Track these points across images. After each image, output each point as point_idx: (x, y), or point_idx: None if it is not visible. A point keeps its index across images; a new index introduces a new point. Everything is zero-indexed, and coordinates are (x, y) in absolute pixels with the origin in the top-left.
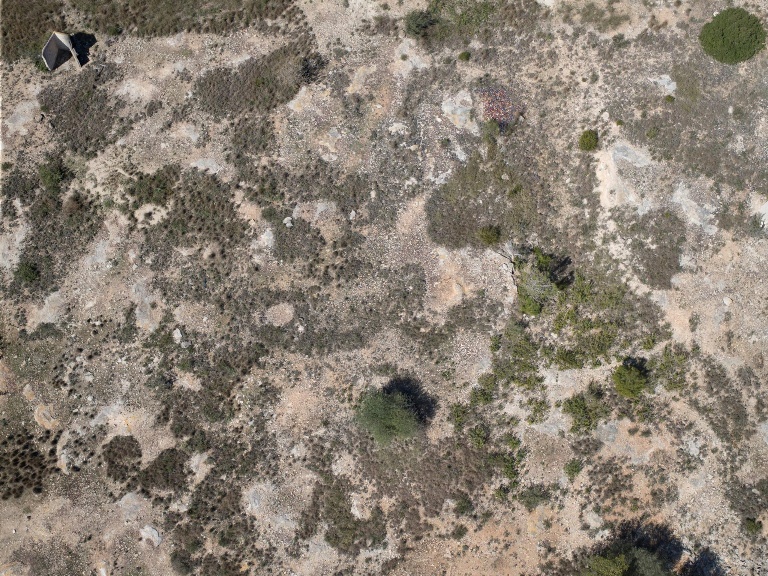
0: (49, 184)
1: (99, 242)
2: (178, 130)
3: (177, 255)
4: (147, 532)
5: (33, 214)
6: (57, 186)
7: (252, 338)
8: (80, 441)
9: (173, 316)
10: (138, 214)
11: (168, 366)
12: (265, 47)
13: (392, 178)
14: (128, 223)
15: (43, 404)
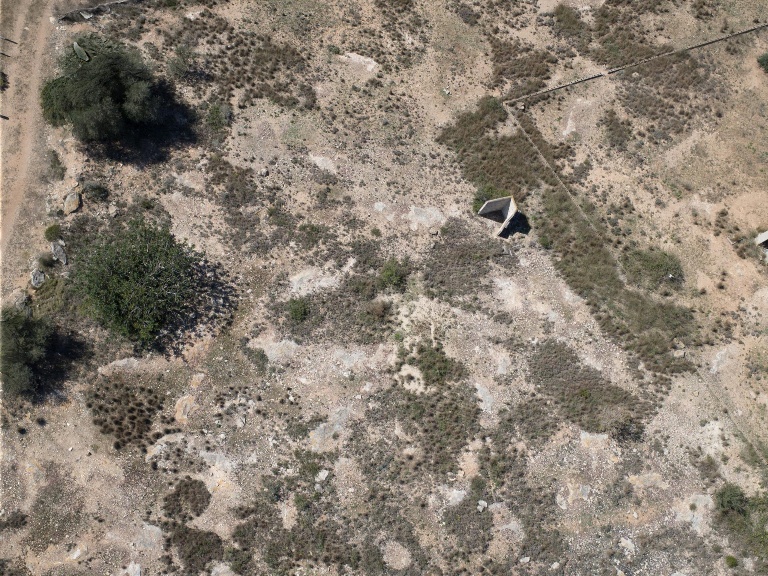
0: (384, 277)
1: (361, 351)
2: (498, 352)
3: (391, 426)
4: (134, 569)
5: (350, 281)
6: (386, 284)
7: (360, 545)
8: (181, 453)
9: (337, 460)
10: (405, 368)
11: (291, 486)
12: (618, 377)
13: (581, 573)
14: (392, 365)
15: (195, 399)
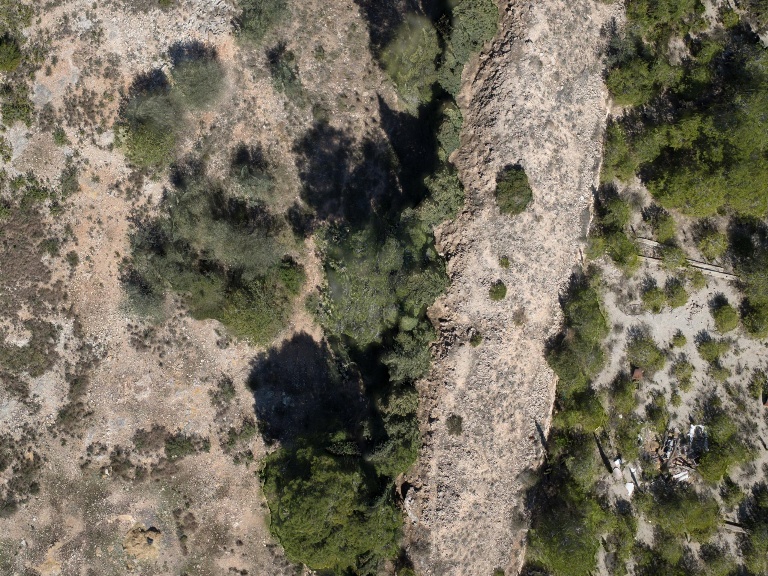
0: None
1: None
2: None
3: None
4: None
5: None
6: None
7: None
8: None
9: None
10: None
11: None
12: None
13: None
14: None
15: None
